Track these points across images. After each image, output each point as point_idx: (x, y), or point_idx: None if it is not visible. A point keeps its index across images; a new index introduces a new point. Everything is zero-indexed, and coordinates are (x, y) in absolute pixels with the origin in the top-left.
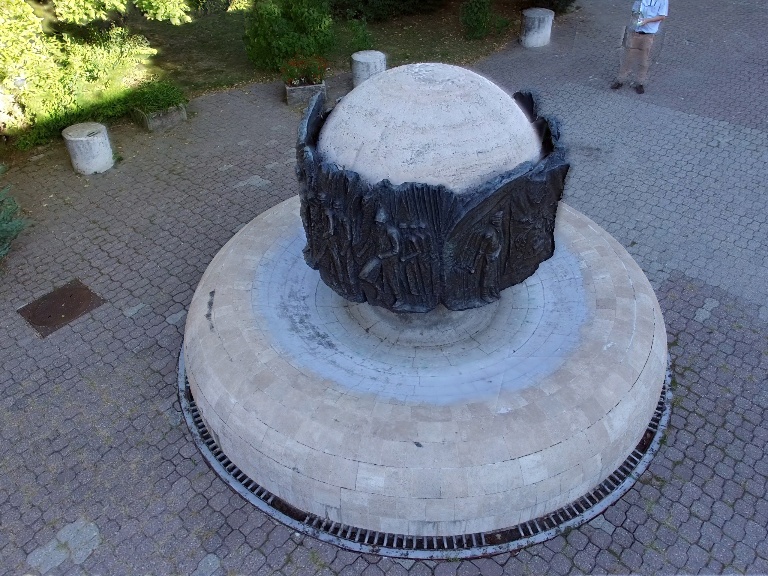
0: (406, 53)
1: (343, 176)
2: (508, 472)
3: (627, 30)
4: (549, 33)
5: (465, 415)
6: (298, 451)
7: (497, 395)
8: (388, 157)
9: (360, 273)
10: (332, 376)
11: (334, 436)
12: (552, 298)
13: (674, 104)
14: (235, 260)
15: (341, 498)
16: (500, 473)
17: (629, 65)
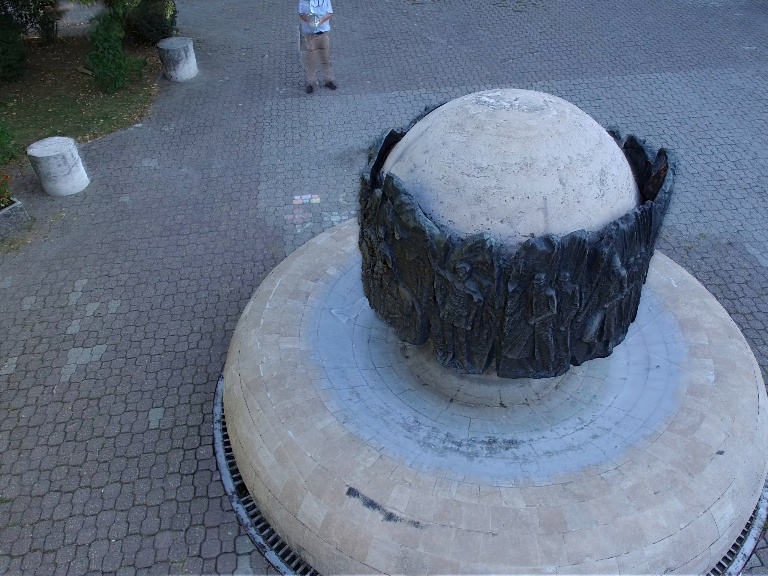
0: (54, 131)
1: (577, 240)
2: (765, 420)
3: (303, 34)
4: (195, 61)
5: (703, 403)
6: (661, 551)
7: (686, 371)
8: (581, 200)
9: (587, 337)
10: (578, 464)
11: (673, 507)
12: None
13: (370, 89)
14: (315, 439)
15: (711, 557)
16: (764, 425)
17: (314, 67)
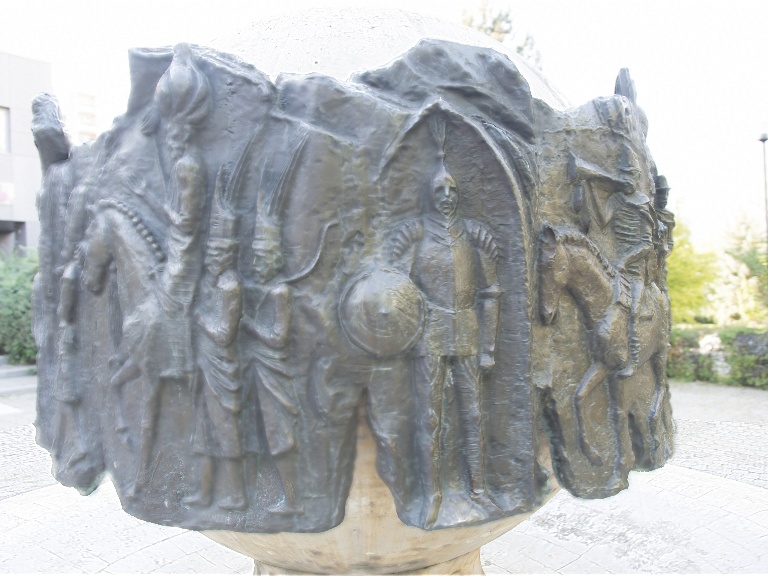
0: None
1: None
2: None
3: None
4: None
5: None
6: None
7: None
8: None
9: None
10: None
11: None
12: (70, 574)
13: None
14: None
15: None
16: None
17: None
